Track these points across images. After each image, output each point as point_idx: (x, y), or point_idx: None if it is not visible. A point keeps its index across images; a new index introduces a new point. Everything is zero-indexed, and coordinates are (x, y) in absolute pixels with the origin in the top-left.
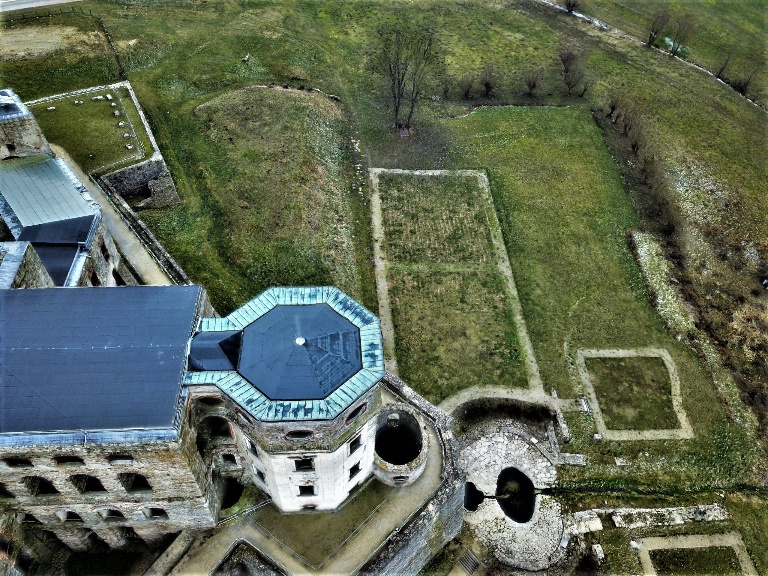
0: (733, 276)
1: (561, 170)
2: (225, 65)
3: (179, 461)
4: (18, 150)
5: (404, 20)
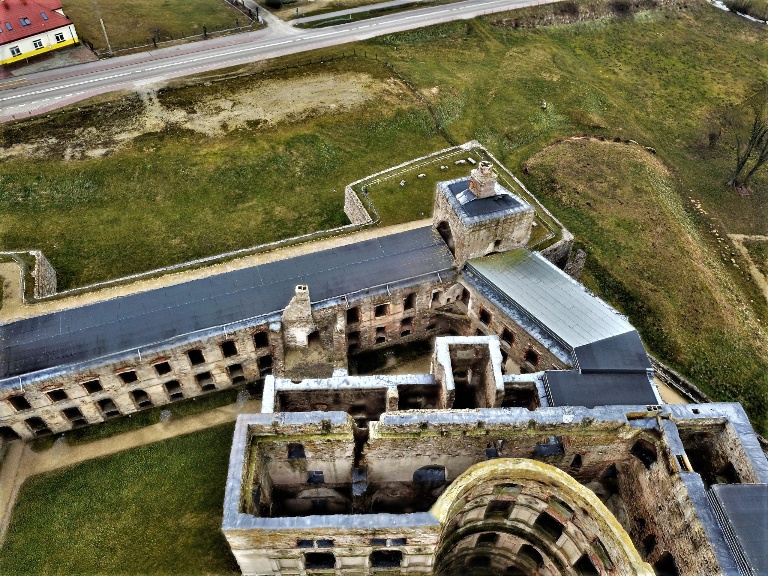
0: None
1: None
2: (528, 114)
3: None
4: (502, 245)
5: (664, 56)
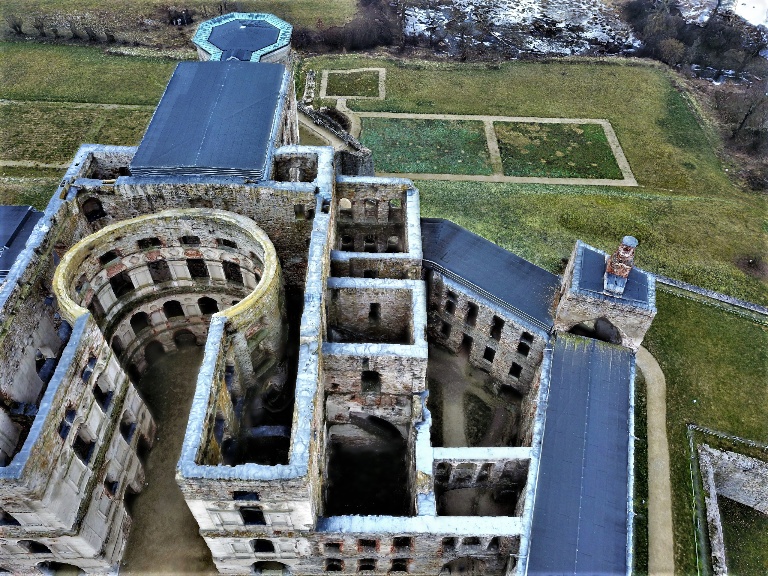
0: (163, 32)
1: (16, 64)
2: None
3: (293, 95)
4: None
5: None
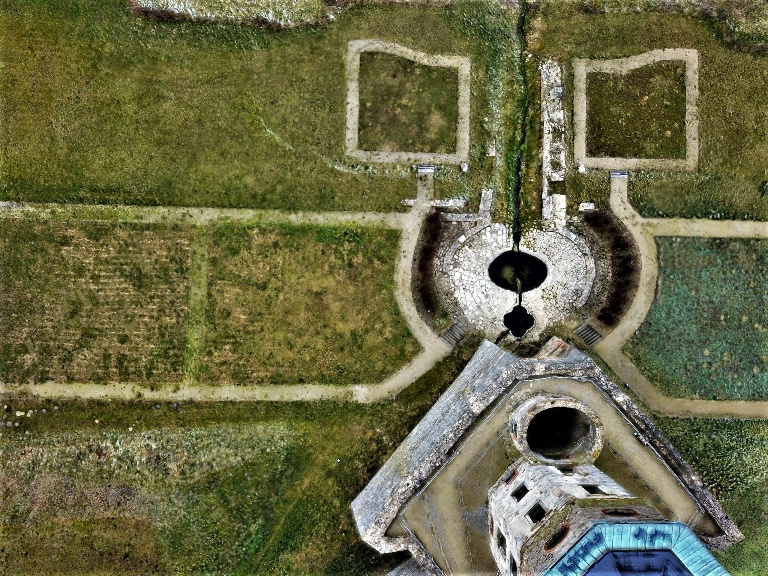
0: None
1: None
2: None
3: None
4: None
5: None
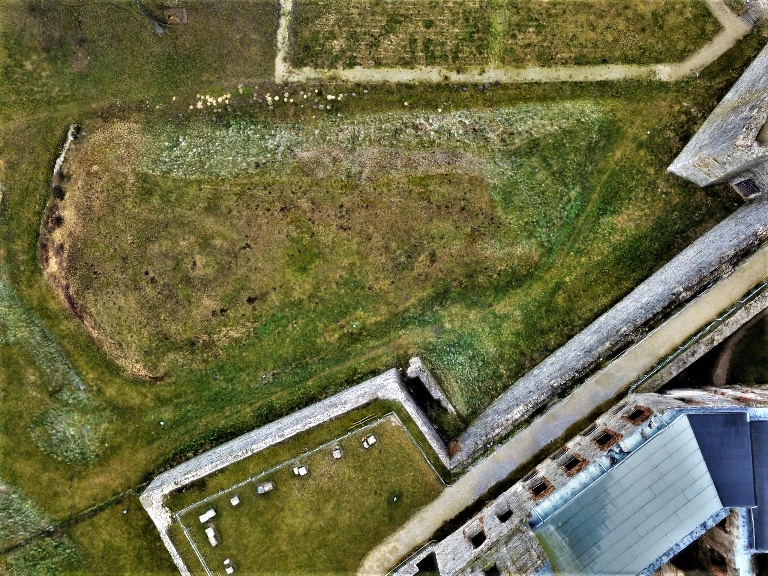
0: None
1: None
2: None
3: None
4: None
5: None
